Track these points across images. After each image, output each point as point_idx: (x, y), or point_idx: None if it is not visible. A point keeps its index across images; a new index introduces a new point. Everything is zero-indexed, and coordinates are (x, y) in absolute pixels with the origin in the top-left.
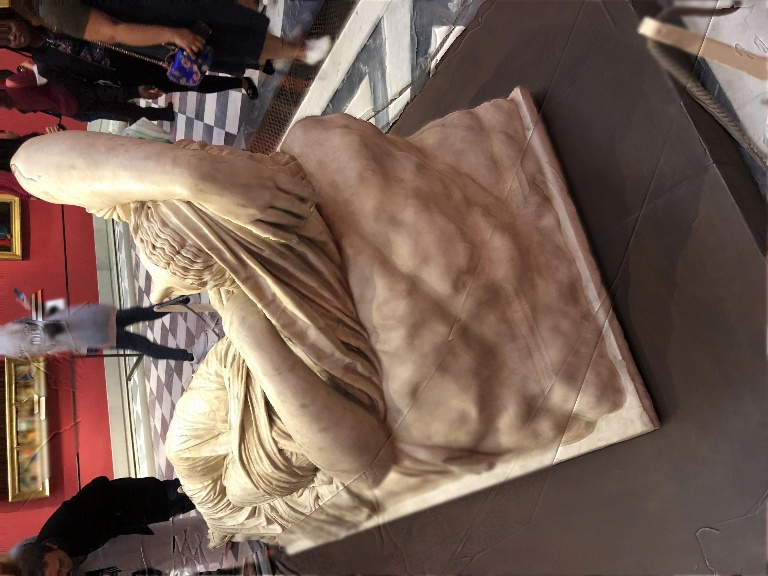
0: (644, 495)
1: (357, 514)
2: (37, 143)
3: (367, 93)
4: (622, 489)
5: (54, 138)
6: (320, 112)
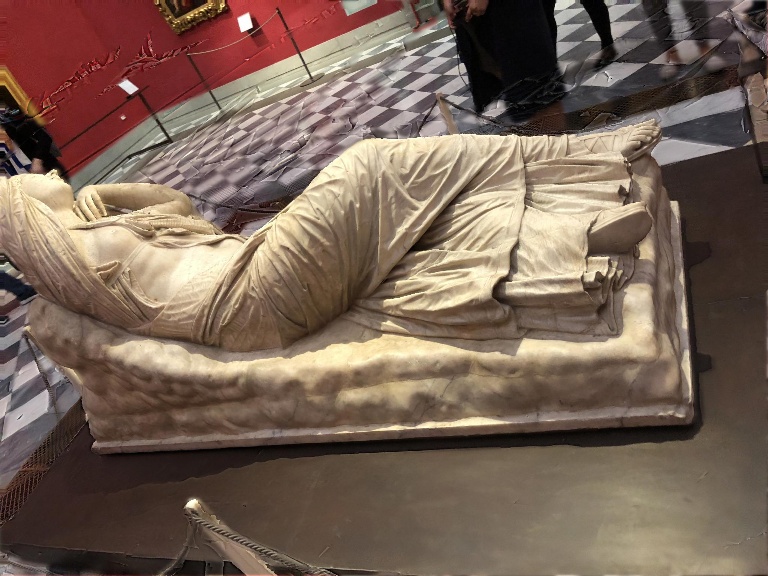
0: None
1: (13, 144)
2: None
3: None
4: None
5: None
6: None
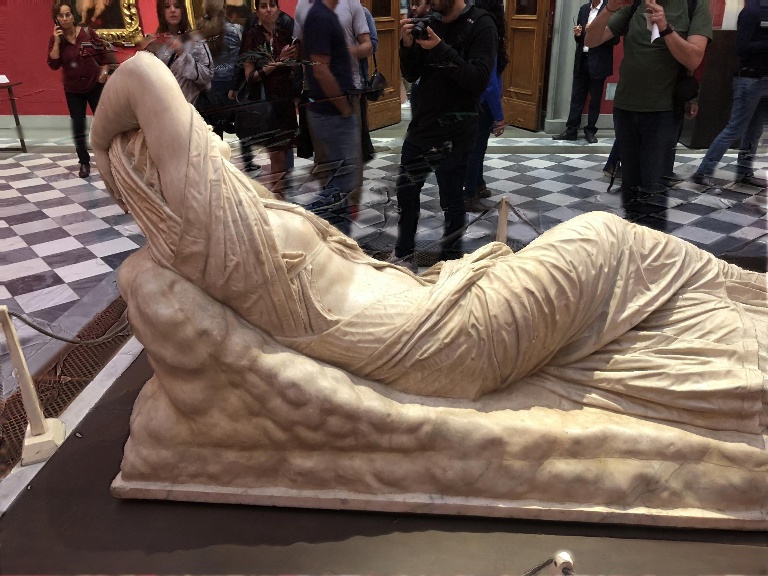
0: None
1: (50, 80)
2: None
3: None
4: None
5: (112, 77)
6: None
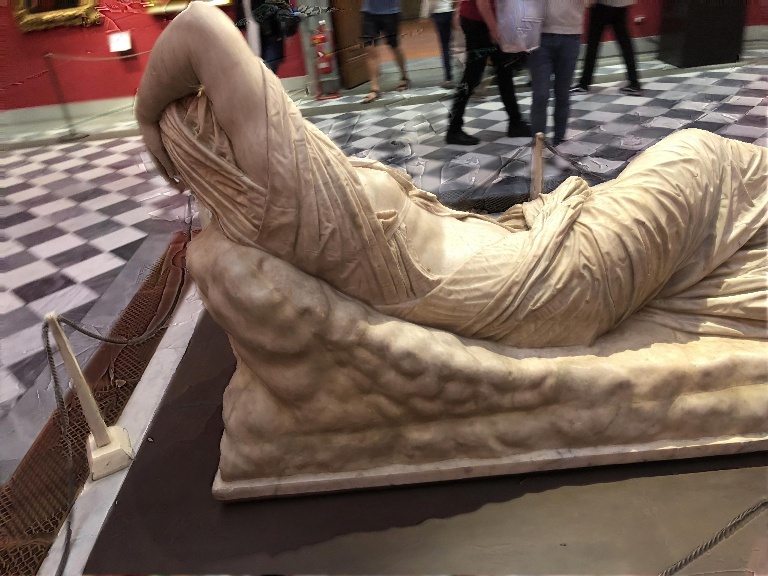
0: None
1: None
2: (171, 23)
3: None
4: None
5: (164, 36)
6: None
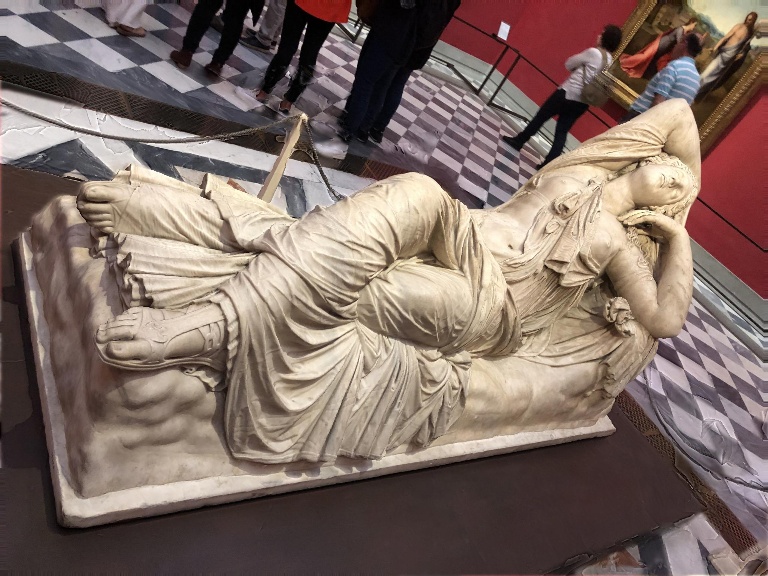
0: (611, 467)
1: None
2: None
3: (275, 193)
4: (600, 464)
5: None
6: (193, 152)
